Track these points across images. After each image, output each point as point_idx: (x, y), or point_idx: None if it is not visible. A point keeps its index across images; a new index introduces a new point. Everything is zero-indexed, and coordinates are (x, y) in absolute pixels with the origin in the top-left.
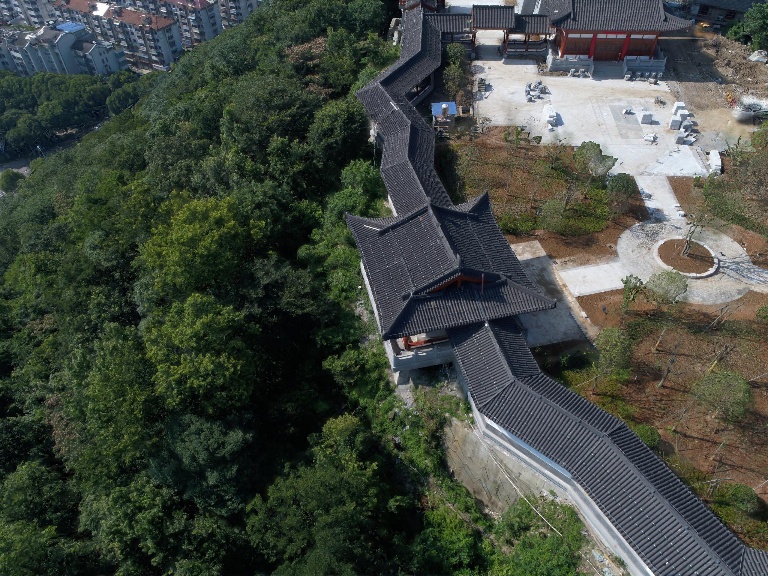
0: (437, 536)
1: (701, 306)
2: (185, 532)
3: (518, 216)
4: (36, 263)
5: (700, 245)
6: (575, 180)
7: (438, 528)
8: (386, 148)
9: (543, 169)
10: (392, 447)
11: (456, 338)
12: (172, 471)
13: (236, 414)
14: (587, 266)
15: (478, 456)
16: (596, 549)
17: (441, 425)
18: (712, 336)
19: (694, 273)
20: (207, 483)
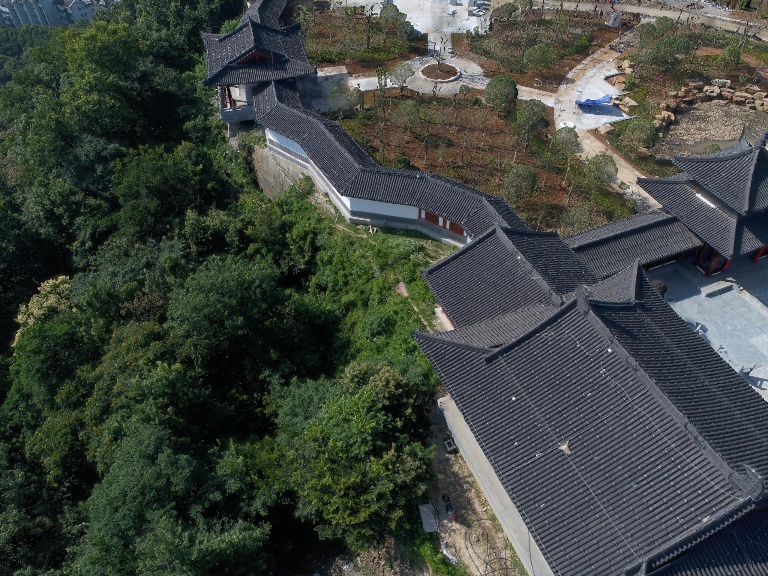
0: (239, 210)
1: (436, 95)
2: (83, 203)
3: (335, 52)
4: (4, 103)
5: (452, 66)
6: (383, 33)
7: (241, 206)
8: (249, 9)
9: (363, 28)
10: (224, 176)
11: (256, 93)
12: (75, 166)
13: (118, 140)
14: (372, 77)
15: (270, 168)
16: (317, 193)
17: (250, 153)
18: (431, 105)
19: (440, 79)
20: (97, 175)
